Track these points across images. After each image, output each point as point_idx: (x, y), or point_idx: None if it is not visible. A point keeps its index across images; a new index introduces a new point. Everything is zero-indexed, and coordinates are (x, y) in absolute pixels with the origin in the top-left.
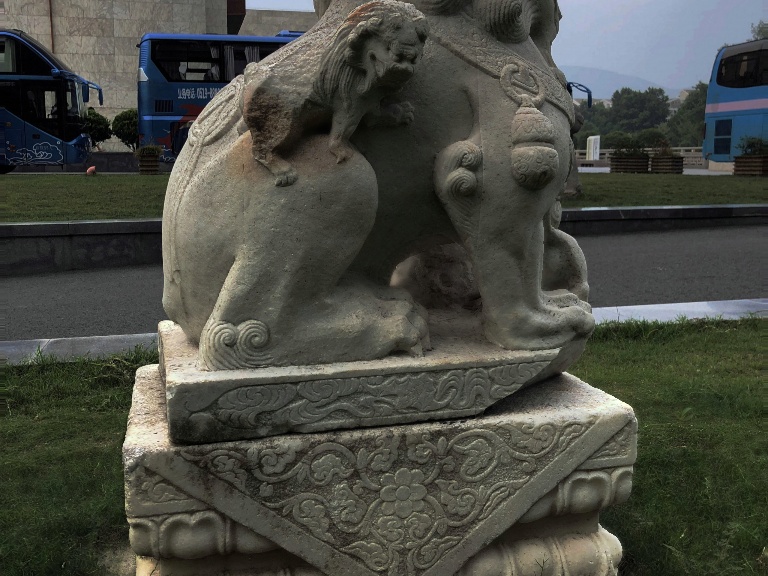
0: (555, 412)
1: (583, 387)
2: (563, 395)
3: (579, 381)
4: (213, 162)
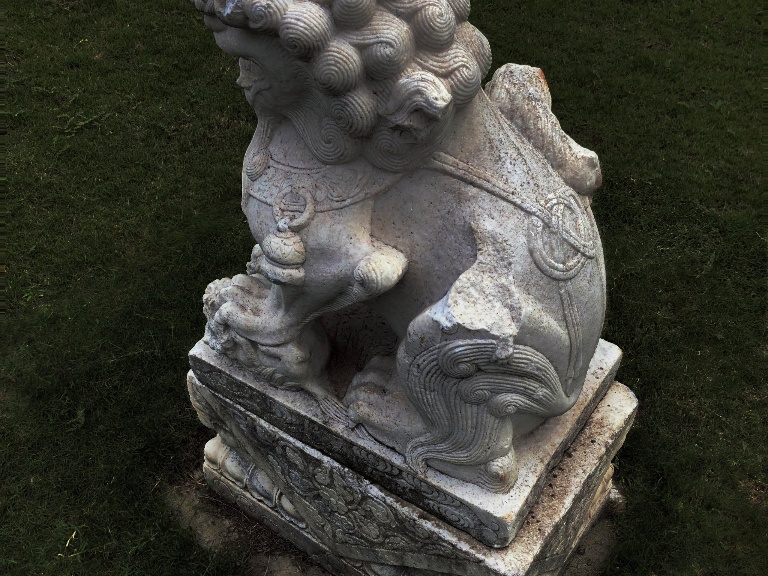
0: None
1: None
2: None
3: None
4: None
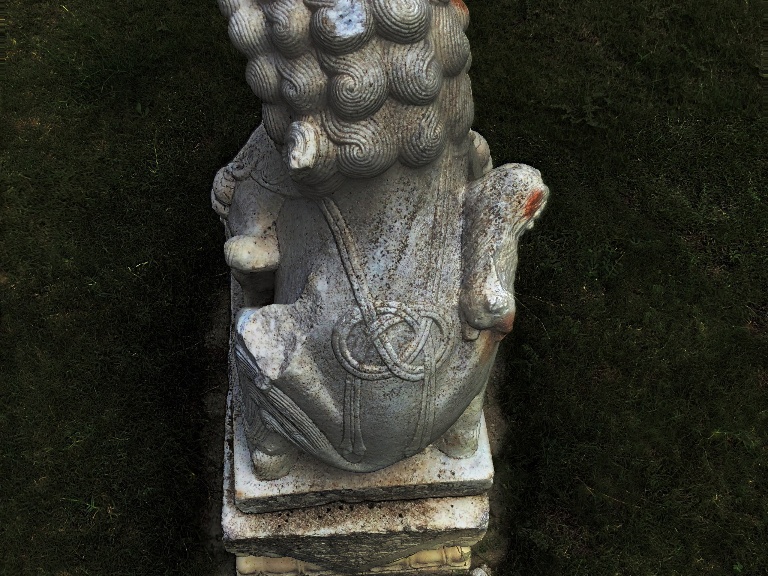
0: None
1: None
2: None
3: None
4: (468, 372)
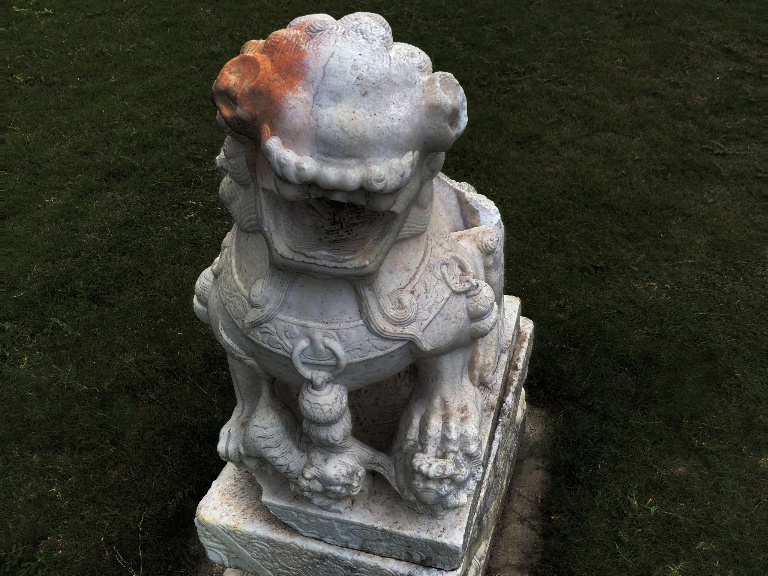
0: (233, 465)
1: (263, 522)
2: (258, 494)
3: (278, 531)
4: None
